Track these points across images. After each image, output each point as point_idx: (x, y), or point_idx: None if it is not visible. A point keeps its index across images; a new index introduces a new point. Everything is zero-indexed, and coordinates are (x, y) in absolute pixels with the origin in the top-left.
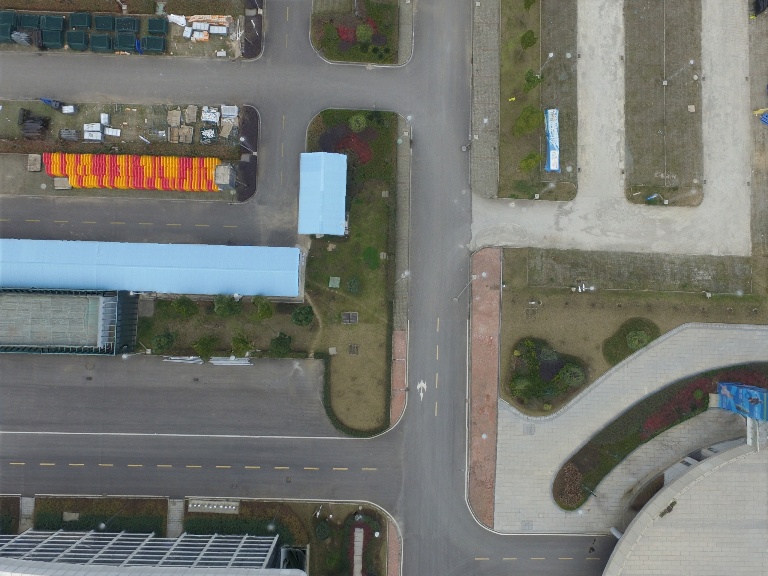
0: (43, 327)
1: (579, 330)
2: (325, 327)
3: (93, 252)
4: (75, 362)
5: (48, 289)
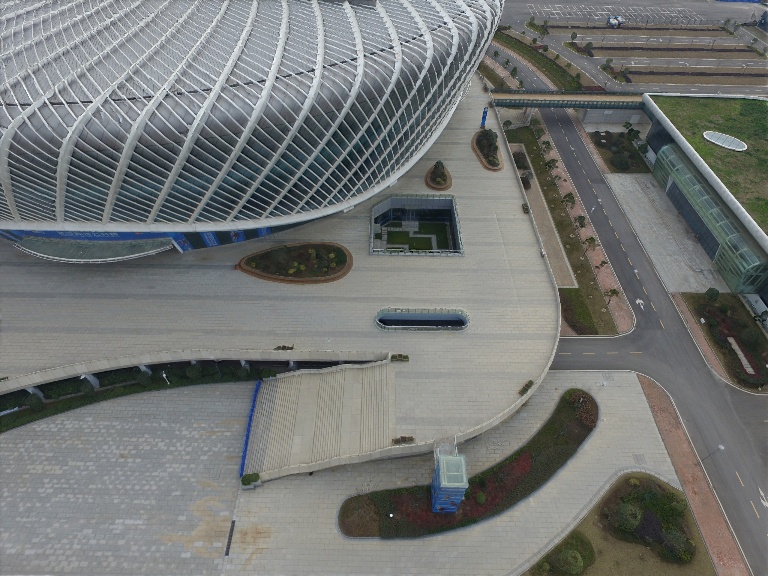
0: None
1: (628, 575)
2: None
3: None
4: None
5: None
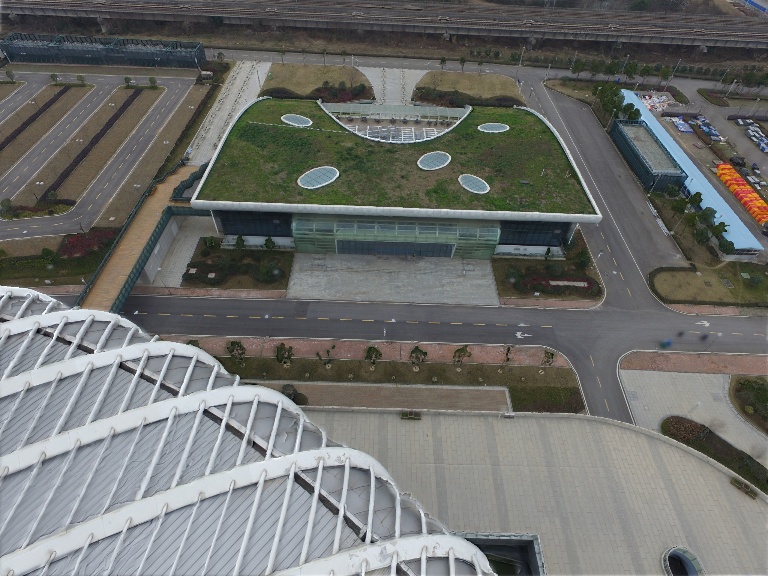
0: (650, 155)
1: None
2: (713, 270)
3: (697, 173)
4: (626, 172)
5: (672, 156)
